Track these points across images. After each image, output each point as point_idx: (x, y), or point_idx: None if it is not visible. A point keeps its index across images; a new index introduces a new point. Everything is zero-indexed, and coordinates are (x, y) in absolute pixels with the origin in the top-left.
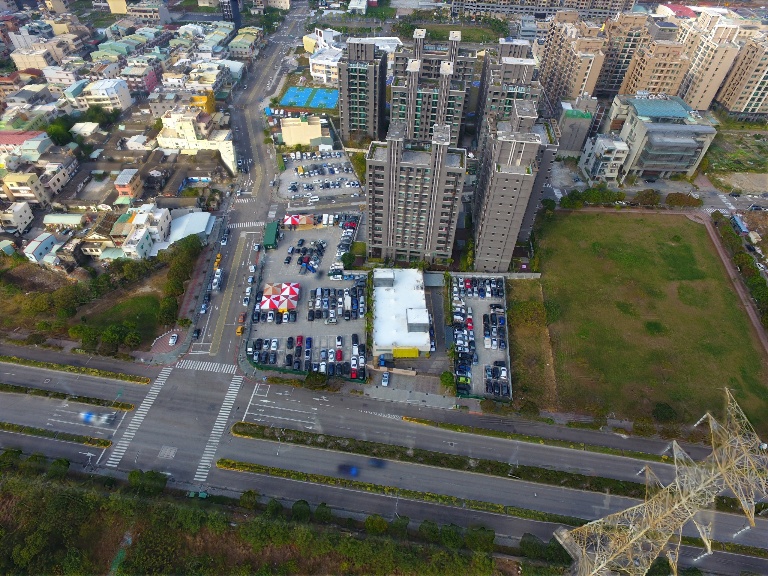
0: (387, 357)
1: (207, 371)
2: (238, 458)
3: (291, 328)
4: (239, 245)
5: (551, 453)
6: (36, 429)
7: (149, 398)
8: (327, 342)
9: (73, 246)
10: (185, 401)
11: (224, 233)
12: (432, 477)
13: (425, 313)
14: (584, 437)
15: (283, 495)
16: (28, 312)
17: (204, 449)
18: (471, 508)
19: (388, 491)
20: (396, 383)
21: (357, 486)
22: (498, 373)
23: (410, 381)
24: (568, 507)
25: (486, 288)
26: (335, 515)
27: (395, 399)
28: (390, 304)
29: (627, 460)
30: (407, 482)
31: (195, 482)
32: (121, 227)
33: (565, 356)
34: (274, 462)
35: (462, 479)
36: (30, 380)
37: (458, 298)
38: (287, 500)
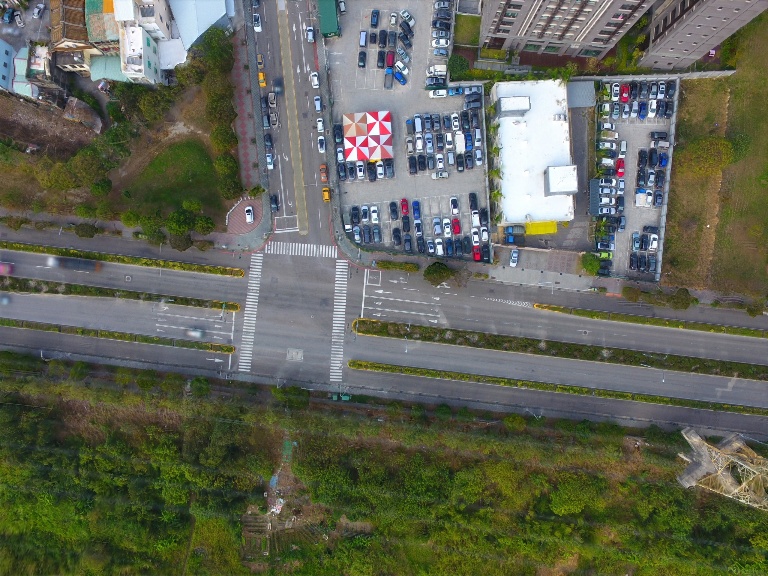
0: (517, 231)
1: (304, 256)
2: (367, 357)
3: (390, 187)
4: (282, 29)
5: (688, 338)
6: (150, 338)
7: (251, 295)
8: (439, 207)
9: (45, 66)
10: (292, 296)
11: (252, 4)
12: (564, 368)
13: (573, 173)
14: (727, 318)
15: (420, 391)
16: (51, 187)
17: (330, 350)
18: (600, 397)
19: (521, 385)
20: (526, 262)
21: (491, 382)
22: (648, 244)
23: (542, 258)
24: (692, 391)
25: (651, 103)
26: (472, 407)
27: (525, 282)
28: (521, 149)
29: (765, 341)
30: (539, 374)
31: (332, 383)
32: (99, 24)
33: (733, 213)
34: (405, 360)
35: (593, 369)
36: (108, 279)
37: (610, 124)
38: (424, 396)
